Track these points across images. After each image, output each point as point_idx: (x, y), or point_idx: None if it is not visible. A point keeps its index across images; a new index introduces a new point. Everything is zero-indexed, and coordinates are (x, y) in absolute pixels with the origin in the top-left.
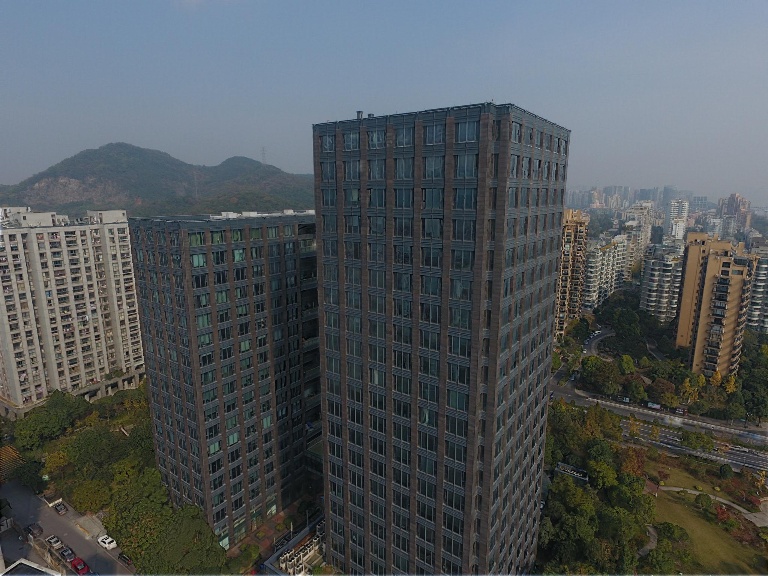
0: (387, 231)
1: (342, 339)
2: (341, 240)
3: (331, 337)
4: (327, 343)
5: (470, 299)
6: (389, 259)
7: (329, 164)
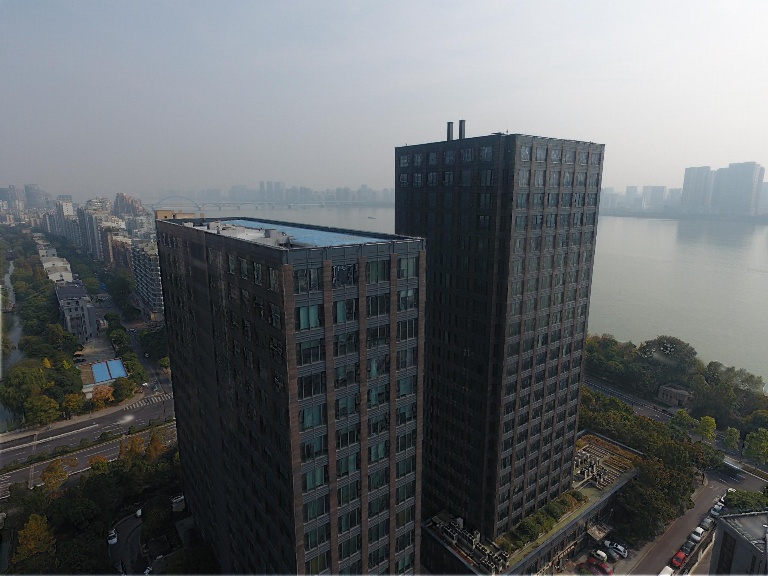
0: (557, 225)
1: (523, 322)
2: (529, 237)
3: (514, 325)
4: (510, 333)
5: (588, 261)
6: (557, 245)
7: (525, 171)
